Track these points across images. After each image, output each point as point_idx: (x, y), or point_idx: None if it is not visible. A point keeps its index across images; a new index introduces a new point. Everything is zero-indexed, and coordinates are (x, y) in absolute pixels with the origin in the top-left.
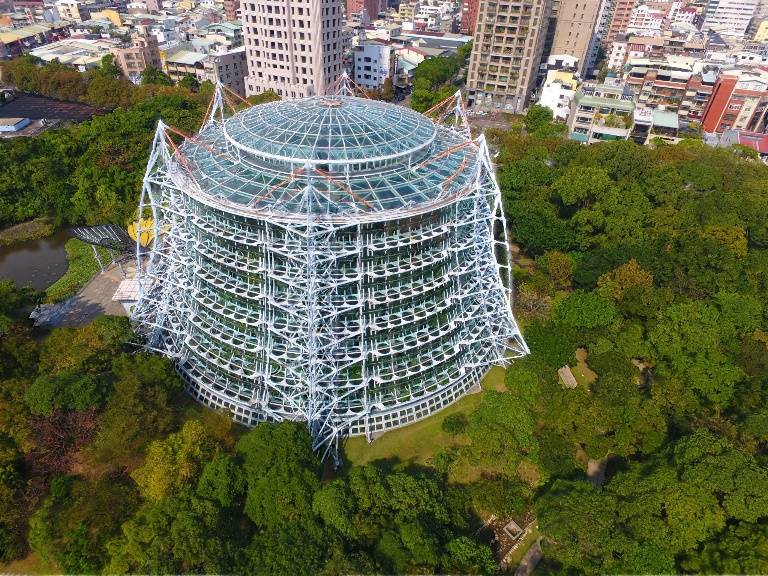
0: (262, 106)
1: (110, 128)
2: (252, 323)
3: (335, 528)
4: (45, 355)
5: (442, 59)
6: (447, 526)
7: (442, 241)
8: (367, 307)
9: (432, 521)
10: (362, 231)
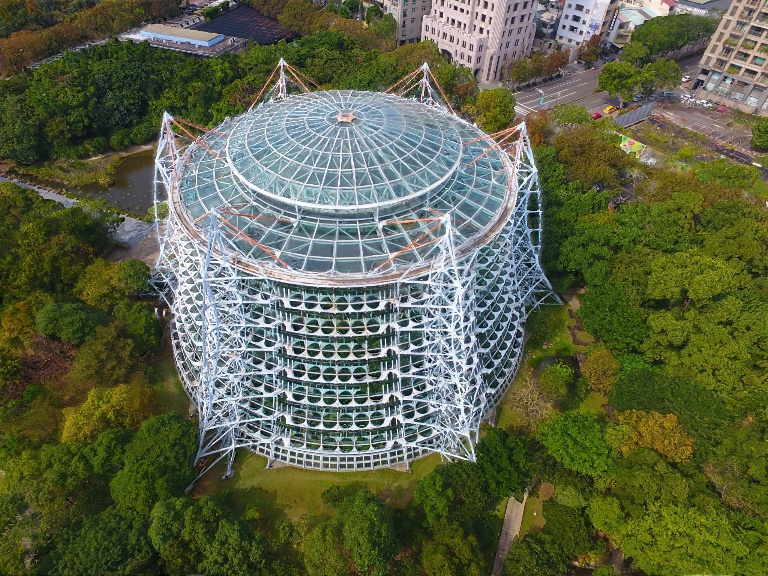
0: (295, 100)
1: (265, 61)
2: (198, 321)
3: (152, 541)
4: (82, 279)
5: (682, 19)
6: None
7: (383, 314)
8: (285, 352)
9: None
10: (279, 283)
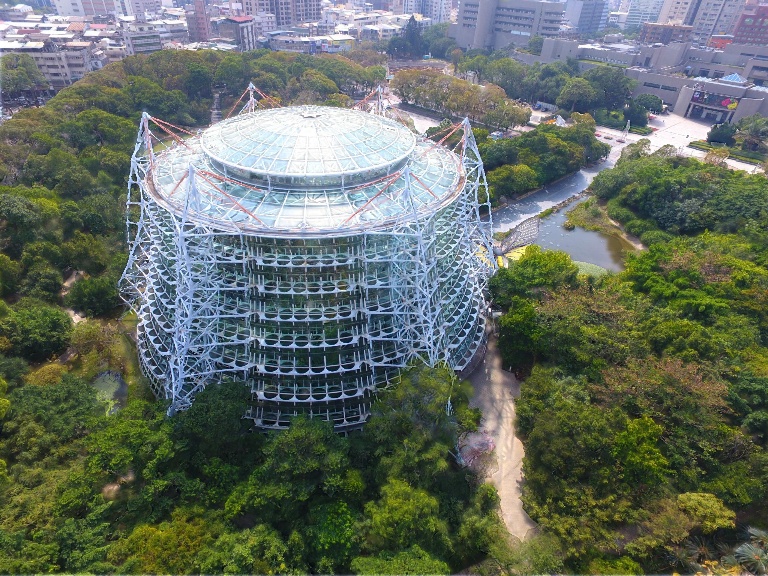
0: (385, 122)
1: None
2: None
3: None
4: None
5: None
6: None
7: None
8: None
9: None
10: None
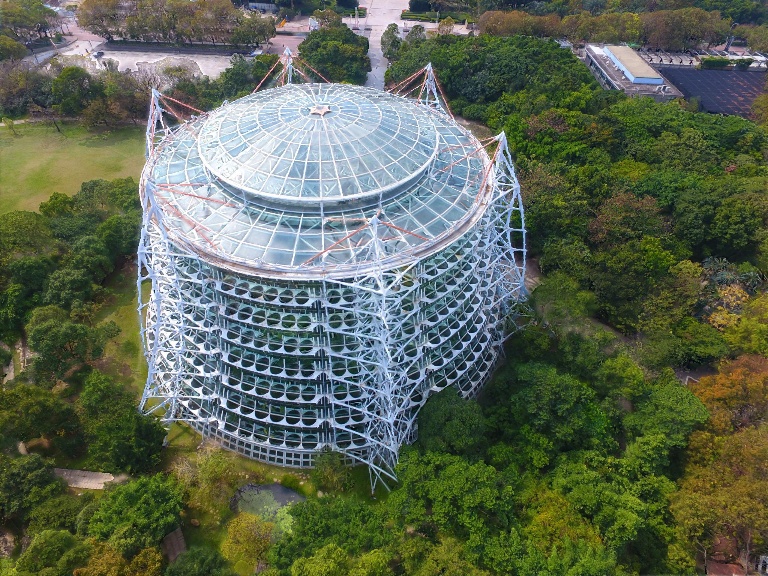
0: None
1: (625, 111)
2: None
3: None
4: None
5: None
6: None
7: None
8: None
9: (47, 289)
10: None
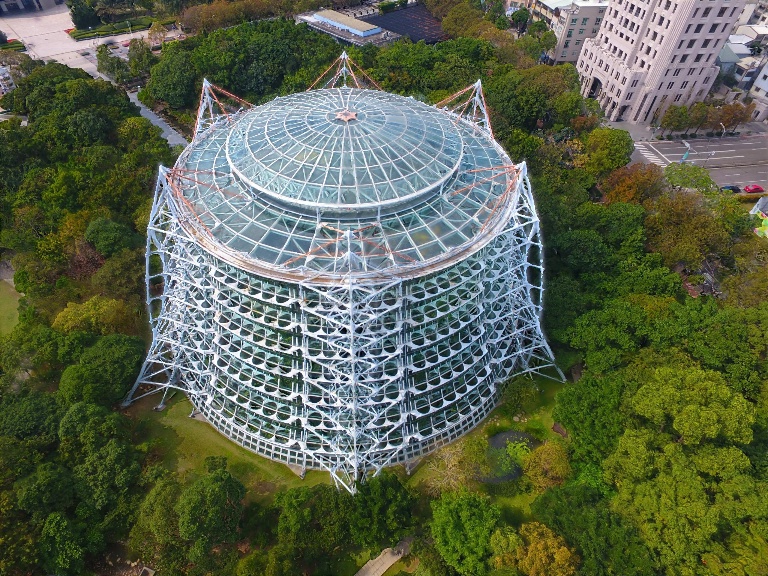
0: (327, 92)
1: (396, 57)
2: None
3: None
4: (141, 207)
5: None
6: (95, 509)
7: (294, 312)
8: None
9: (88, 494)
10: None
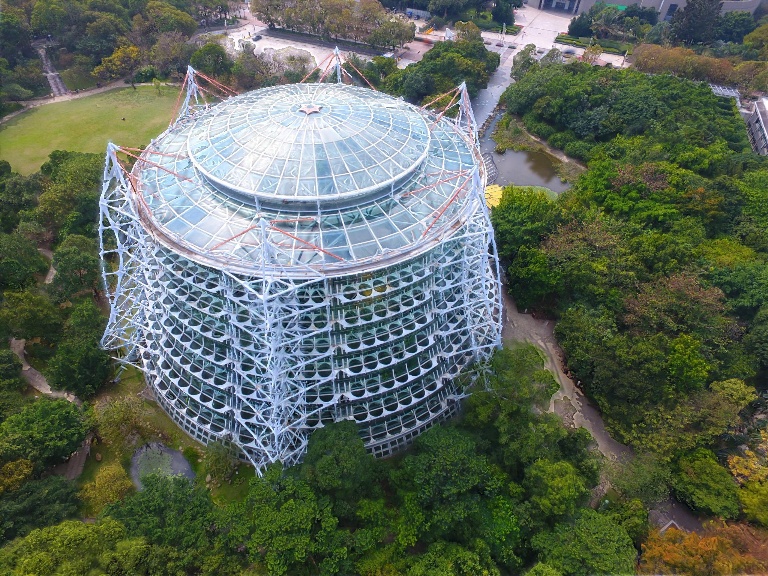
0: (381, 99)
1: (756, 181)
2: None
3: None
4: None
5: None
6: None
7: None
8: None
9: None
10: None
